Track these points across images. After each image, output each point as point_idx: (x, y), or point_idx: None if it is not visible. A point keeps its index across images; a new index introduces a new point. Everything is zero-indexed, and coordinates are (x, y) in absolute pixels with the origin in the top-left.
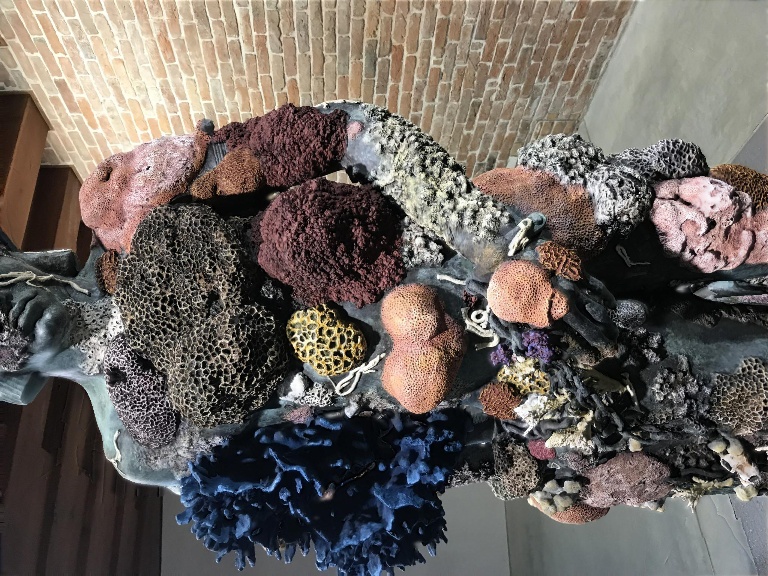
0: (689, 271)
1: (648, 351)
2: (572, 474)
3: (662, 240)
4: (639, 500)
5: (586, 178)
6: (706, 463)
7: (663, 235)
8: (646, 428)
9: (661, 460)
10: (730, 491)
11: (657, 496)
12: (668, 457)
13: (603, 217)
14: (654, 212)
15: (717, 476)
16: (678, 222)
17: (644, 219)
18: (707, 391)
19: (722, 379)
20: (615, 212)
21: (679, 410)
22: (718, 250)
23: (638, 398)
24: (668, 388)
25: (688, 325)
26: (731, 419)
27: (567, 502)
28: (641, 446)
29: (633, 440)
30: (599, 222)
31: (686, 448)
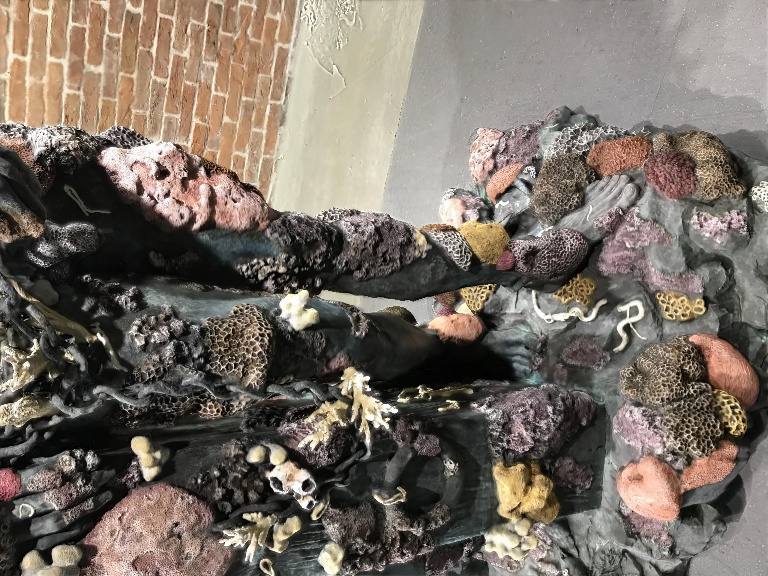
0: (161, 231)
1: (120, 296)
2: (56, 521)
3: (114, 180)
4: (182, 575)
5: (27, 135)
6: (256, 494)
7: (114, 175)
8: (131, 386)
9: (194, 494)
10: (317, 569)
11: (208, 567)
12: (205, 493)
13: (40, 149)
14: (102, 158)
15: (272, 507)
16: (127, 163)
17: (90, 160)
18: (195, 327)
19: (213, 321)
20: (52, 144)
21: (166, 351)
22: (180, 200)
23: (114, 348)
24: (149, 330)
25: (173, 287)
26: (235, 366)
27: (51, 571)
28: (156, 464)
29: (142, 454)
30: (37, 155)
31: (222, 469)
